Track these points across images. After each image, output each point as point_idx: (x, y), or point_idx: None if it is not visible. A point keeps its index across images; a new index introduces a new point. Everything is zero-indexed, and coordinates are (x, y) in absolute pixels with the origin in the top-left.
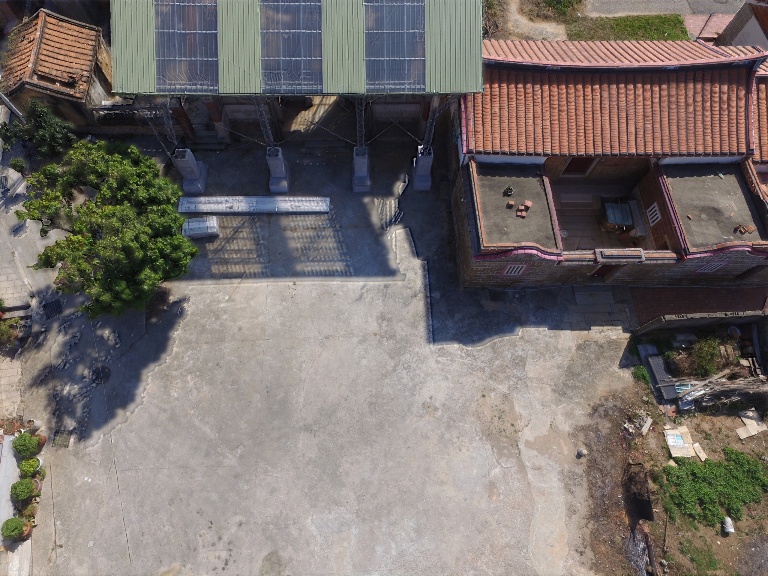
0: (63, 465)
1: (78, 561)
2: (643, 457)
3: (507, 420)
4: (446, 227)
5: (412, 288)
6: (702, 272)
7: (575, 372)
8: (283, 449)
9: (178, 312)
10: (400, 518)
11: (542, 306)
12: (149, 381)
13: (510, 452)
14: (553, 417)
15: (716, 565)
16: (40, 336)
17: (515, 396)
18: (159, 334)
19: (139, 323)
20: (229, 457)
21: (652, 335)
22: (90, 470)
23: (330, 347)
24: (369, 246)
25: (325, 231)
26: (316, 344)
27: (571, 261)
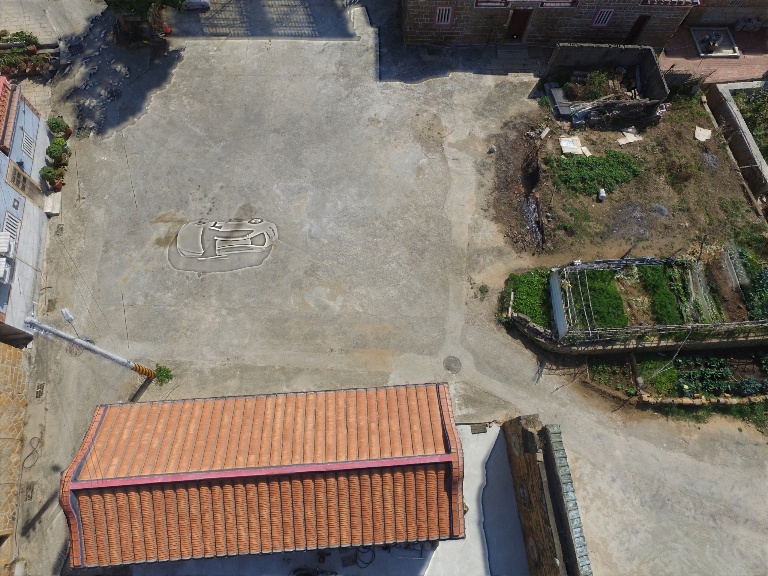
0: (85, 149)
1: (97, 207)
2: (540, 153)
3: (435, 130)
4: (396, 6)
5: (365, 45)
6: (598, 26)
7: (492, 101)
8: (256, 143)
9: (176, 57)
10: (346, 187)
11: (470, 59)
12: (152, 99)
13: (435, 149)
14: (472, 129)
15: (590, 219)
16: (66, 68)
17: (443, 115)
18: (160, 71)
19: (145, 62)
20: (214, 147)
21: (555, 73)
22: (106, 153)
23: (297, 81)
24: (332, 18)
25: (296, 7)
26: (285, 79)
27: (487, 2)
